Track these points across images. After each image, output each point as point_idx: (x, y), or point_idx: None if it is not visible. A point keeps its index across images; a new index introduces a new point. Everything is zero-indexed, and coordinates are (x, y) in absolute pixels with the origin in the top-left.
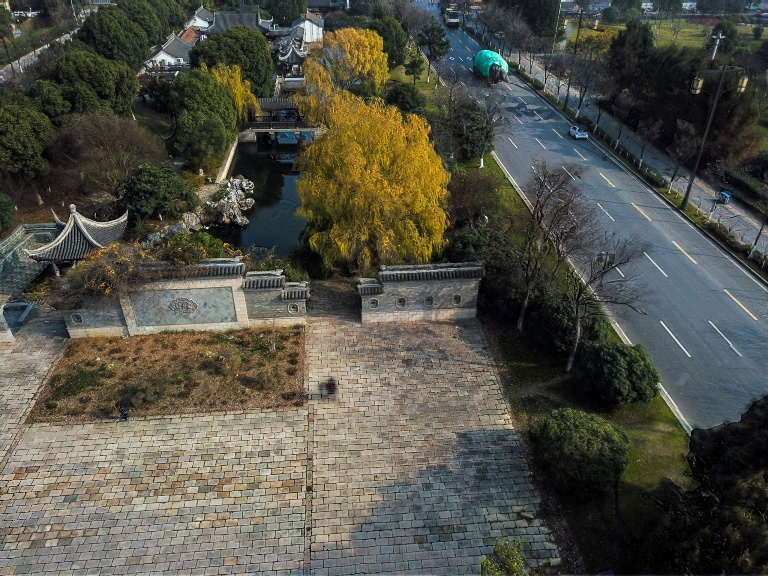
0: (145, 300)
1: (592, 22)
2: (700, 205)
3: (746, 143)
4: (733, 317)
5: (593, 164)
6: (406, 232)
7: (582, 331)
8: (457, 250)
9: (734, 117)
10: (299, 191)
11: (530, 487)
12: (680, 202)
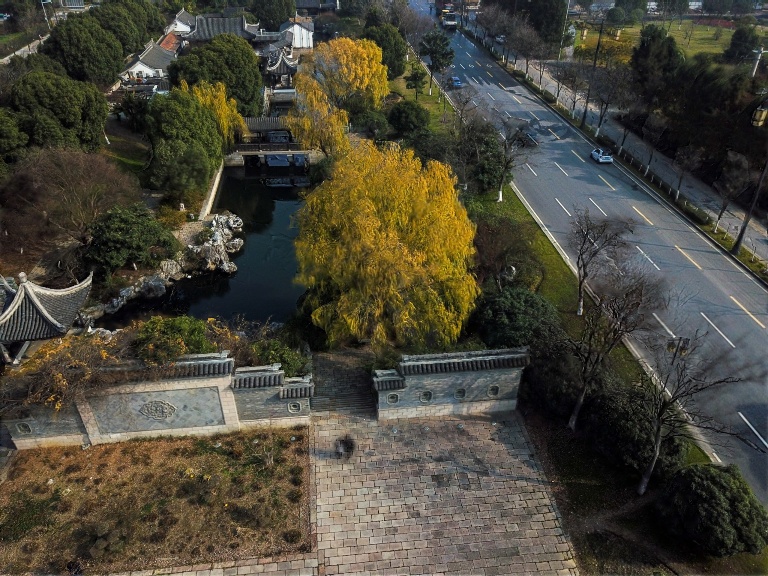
0: (109, 405)
1: (614, 32)
2: None
3: None
4: None
5: (623, 195)
6: (429, 306)
7: (659, 445)
8: (486, 318)
9: None
10: (298, 255)
11: None
12: (731, 245)
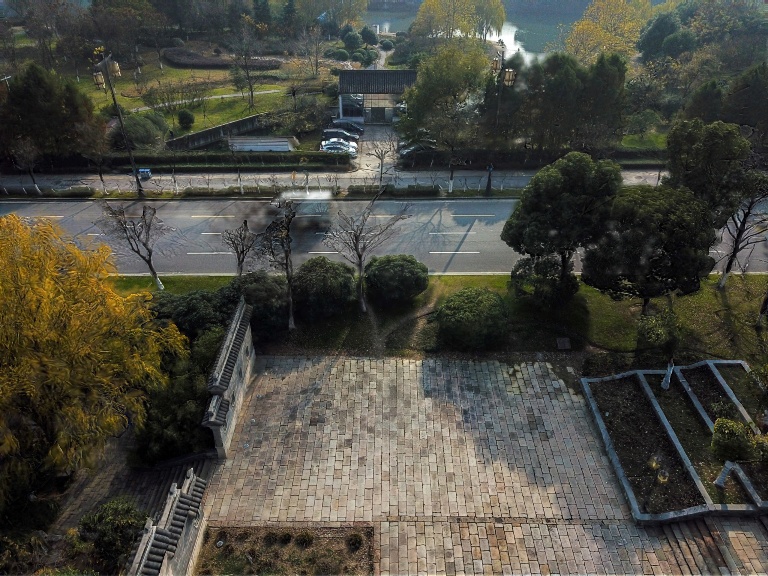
0: None
1: None
2: (144, 187)
3: (102, 126)
4: (315, 223)
5: None
6: (148, 342)
7: None
8: None
9: (83, 107)
10: None
11: (485, 364)
12: (134, 193)
